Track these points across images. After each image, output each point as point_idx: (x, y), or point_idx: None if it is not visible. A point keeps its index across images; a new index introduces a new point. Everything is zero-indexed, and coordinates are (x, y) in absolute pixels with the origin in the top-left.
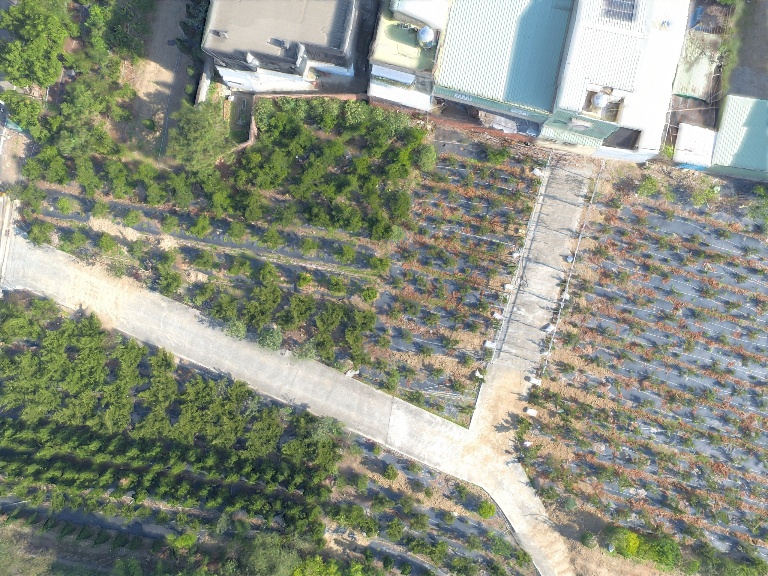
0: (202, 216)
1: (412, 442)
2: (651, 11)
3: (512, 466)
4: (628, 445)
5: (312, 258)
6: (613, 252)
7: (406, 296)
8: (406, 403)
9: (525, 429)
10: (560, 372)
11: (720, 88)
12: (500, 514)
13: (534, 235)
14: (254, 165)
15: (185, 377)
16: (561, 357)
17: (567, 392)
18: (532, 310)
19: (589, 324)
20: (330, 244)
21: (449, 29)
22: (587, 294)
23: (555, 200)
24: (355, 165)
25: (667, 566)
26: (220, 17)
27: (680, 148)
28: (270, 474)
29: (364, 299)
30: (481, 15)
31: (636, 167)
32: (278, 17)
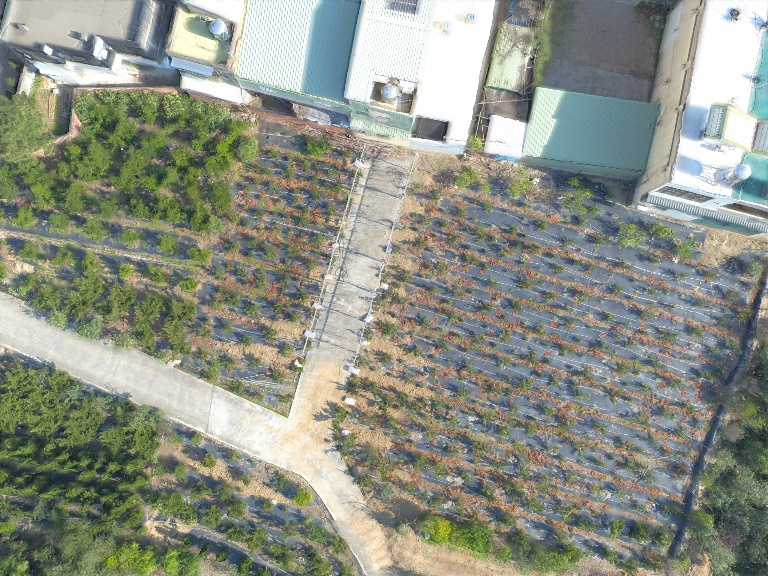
0: (24, 207)
1: (232, 431)
2: (457, 4)
3: (331, 454)
4: (446, 433)
5: (136, 249)
6: (433, 243)
7: (228, 286)
8: (227, 392)
9: (342, 417)
10: (379, 361)
11: (533, 80)
12: (319, 502)
13: (354, 226)
14: (74, 157)
15: (10, 366)
16: (380, 346)
17: (386, 381)
18: (351, 300)
19: (408, 314)
20: (153, 235)
21: (246, 21)
22: (406, 284)
23: (376, 191)
24: (173, 157)
25: (482, 553)
26: (21, 10)
27: (491, 139)
28: (84, 462)
29: (181, 289)
30: (277, 8)
31: (456, 159)
32: (78, 10)
